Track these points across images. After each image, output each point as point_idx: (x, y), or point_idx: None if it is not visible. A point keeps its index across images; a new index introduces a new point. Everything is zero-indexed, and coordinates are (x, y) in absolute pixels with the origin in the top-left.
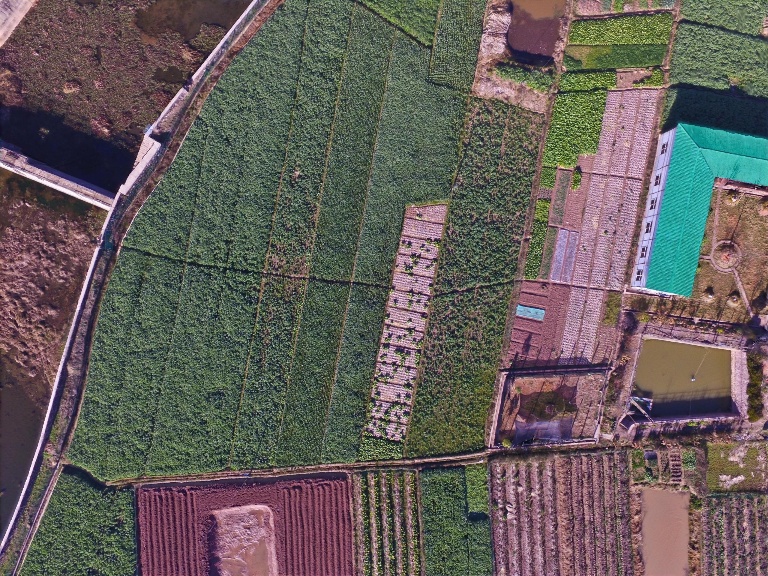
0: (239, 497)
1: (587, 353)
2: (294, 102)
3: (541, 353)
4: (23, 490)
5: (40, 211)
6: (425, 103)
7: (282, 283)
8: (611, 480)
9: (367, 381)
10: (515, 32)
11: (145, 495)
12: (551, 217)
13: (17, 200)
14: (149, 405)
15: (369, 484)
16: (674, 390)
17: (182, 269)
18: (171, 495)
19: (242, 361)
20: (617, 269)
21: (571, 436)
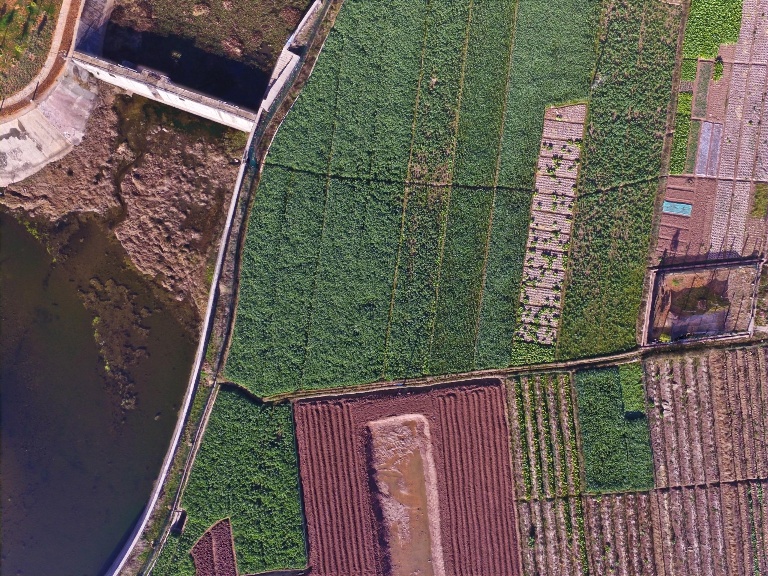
0: (395, 407)
1: (736, 246)
2: (428, 8)
3: (690, 248)
4: (185, 408)
5: (177, 136)
6: (561, 1)
7: (425, 192)
8: (767, 372)
9: (516, 285)
10: None
11: (302, 409)
12: (694, 110)
13: (154, 126)
14: (301, 320)
15: (522, 389)
16: None
17: (325, 183)
18: (327, 408)
19: (391, 271)
20: (763, 159)
21: (725, 330)
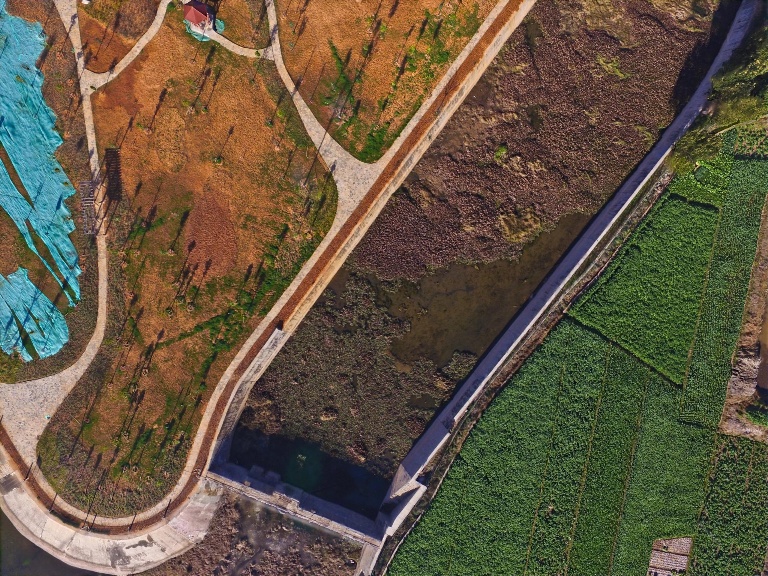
0: None
1: None
2: (550, 440)
3: None
4: None
5: (297, 535)
6: (677, 443)
7: None
8: None
9: None
10: (762, 371)
11: None
12: None
13: (275, 524)
14: None
15: None
16: None
17: None
18: None
19: None
20: None
21: None
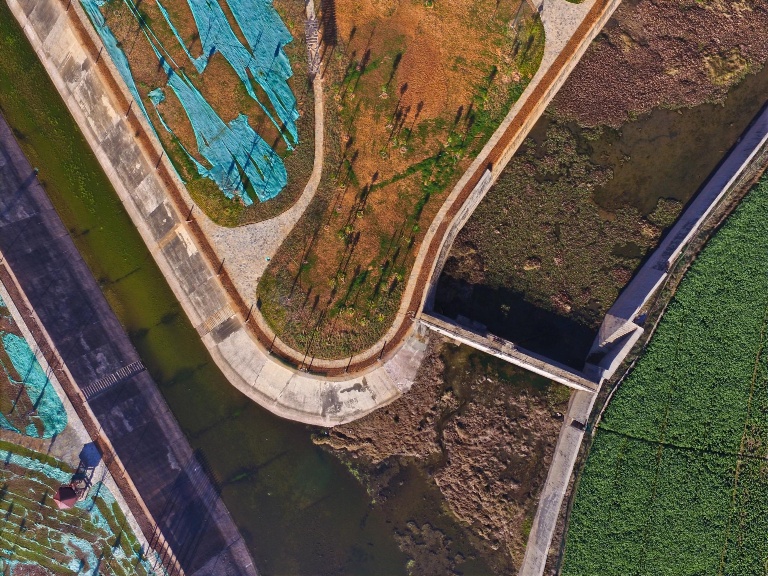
0: None
1: None
2: None
3: None
4: None
5: (502, 386)
6: None
7: (758, 465)
8: None
9: None
10: None
11: None
12: None
13: (479, 376)
14: None
15: None
16: None
17: (658, 451)
18: None
19: (721, 545)
20: None
21: None
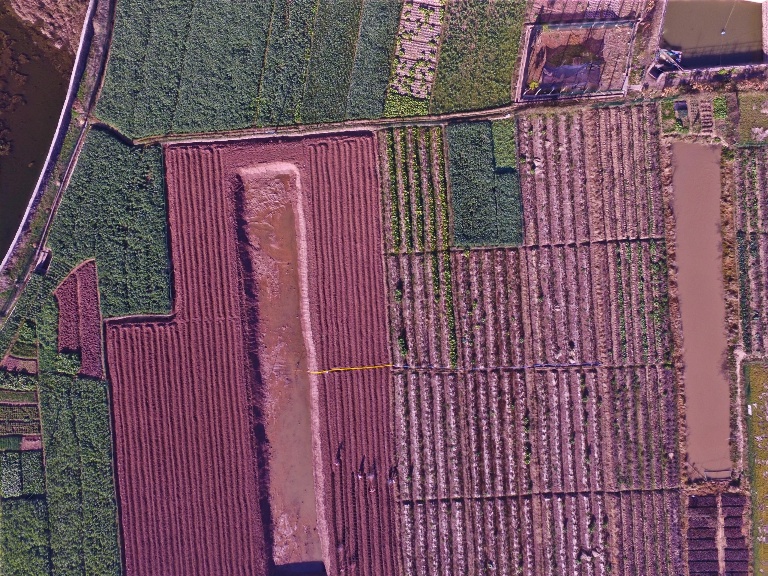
0: (265, 153)
1: (614, 6)
2: None
3: (567, 6)
4: (52, 142)
5: None
6: None
7: None
8: (640, 132)
9: (391, 36)
10: None
11: (172, 153)
12: None
13: None
14: (174, 61)
15: (395, 141)
16: (703, 44)
17: None
18: (198, 152)
19: (266, 17)
20: None
21: None
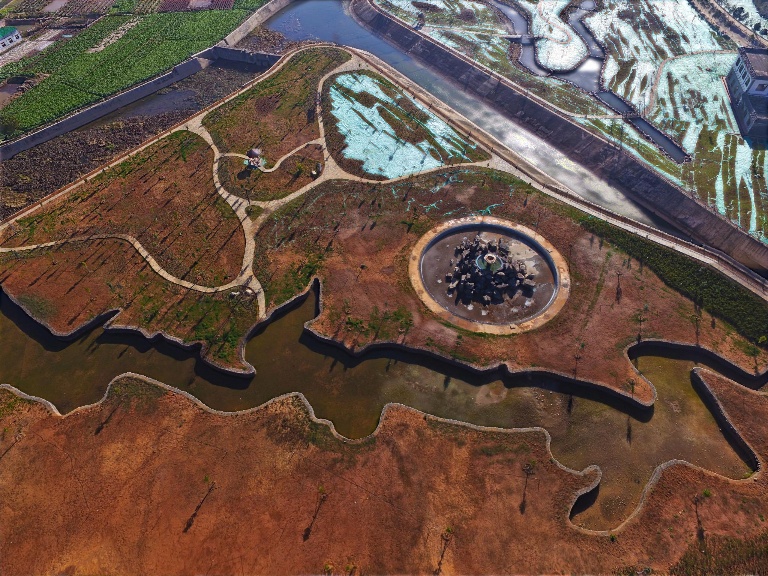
0: (196, 8)
1: None
2: None
3: None
4: (266, 5)
5: None
6: None
7: None
8: None
9: None
10: None
11: None
12: None
13: None
14: None
15: None
16: None
17: None
18: (220, 8)
19: None
20: None
21: None
